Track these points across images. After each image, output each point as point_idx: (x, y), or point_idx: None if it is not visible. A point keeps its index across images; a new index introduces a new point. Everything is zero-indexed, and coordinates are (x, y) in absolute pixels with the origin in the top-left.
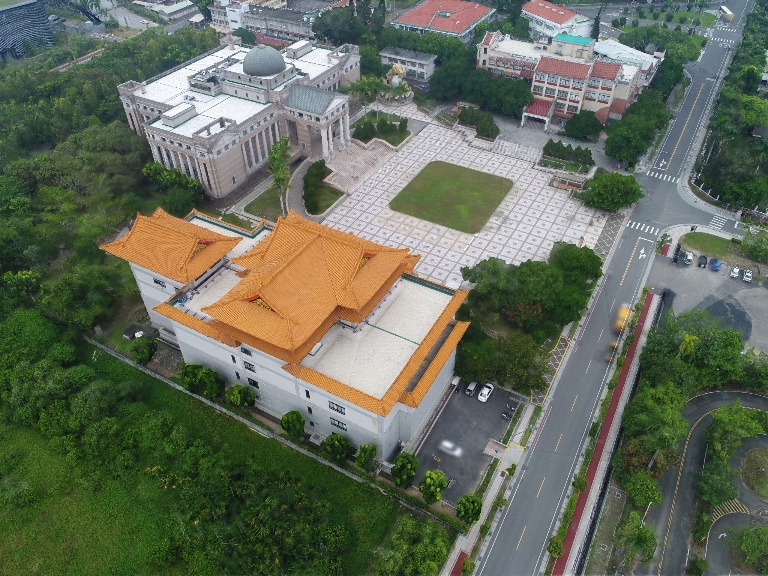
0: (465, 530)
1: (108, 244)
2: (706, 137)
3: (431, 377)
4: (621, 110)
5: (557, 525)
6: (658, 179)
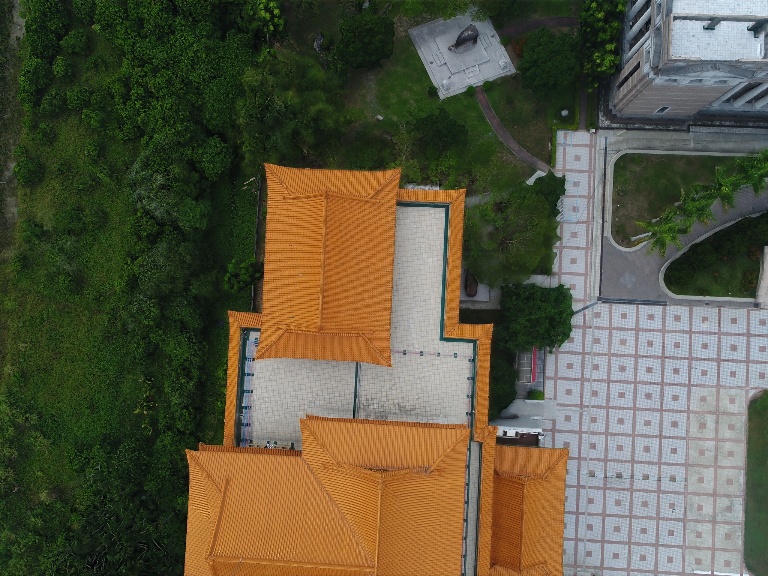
0: None
1: (278, 170)
2: None
3: None
4: None
5: None
6: None
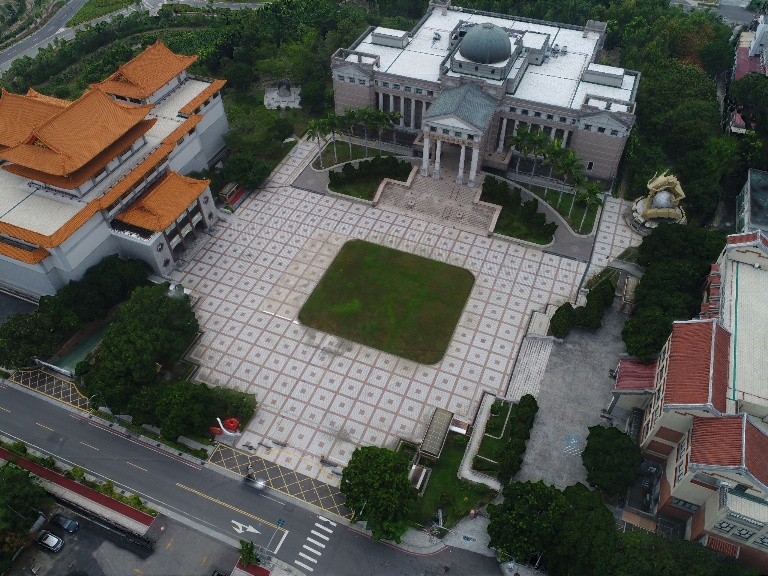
0: None
1: None
2: None
3: None
4: (694, 533)
5: None
6: None
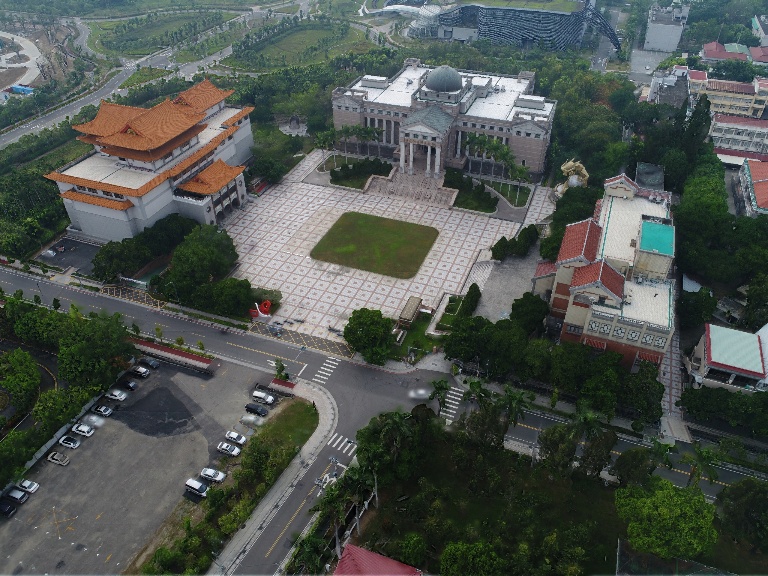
0: (20, 260)
1: None
2: (610, 482)
3: (81, 199)
4: None
5: (7, 296)
6: None
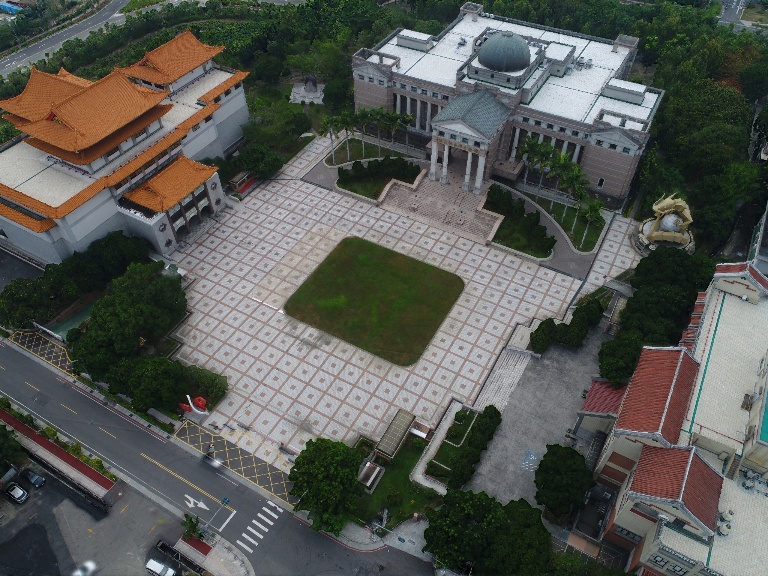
0: None
1: None
2: None
3: None
4: None
5: None
6: None
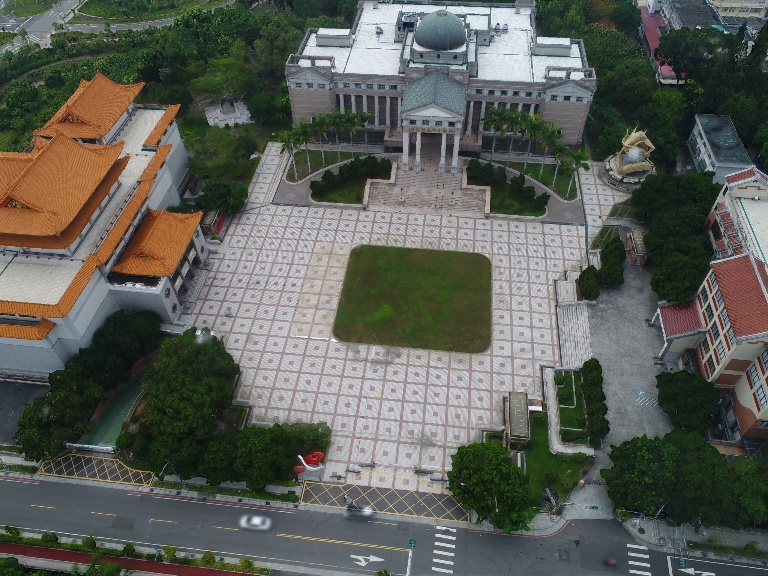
0: None
1: None
2: None
3: None
4: None
5: None
6: (625, 568)
